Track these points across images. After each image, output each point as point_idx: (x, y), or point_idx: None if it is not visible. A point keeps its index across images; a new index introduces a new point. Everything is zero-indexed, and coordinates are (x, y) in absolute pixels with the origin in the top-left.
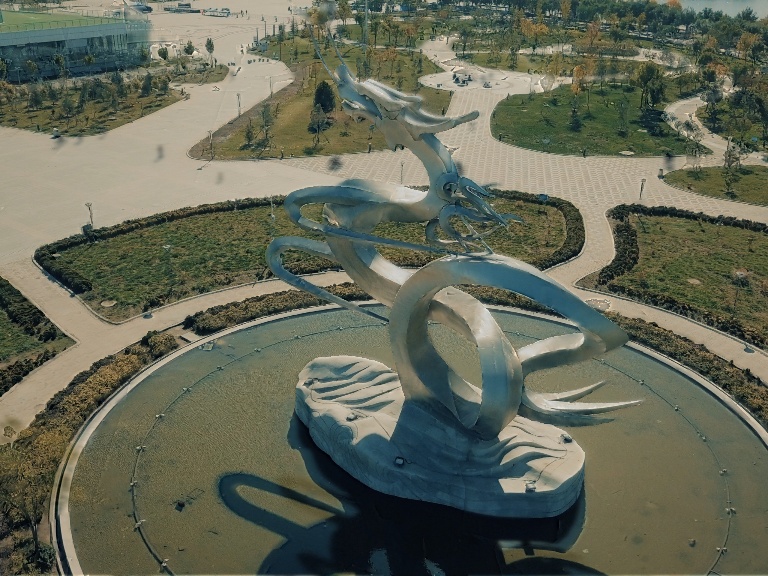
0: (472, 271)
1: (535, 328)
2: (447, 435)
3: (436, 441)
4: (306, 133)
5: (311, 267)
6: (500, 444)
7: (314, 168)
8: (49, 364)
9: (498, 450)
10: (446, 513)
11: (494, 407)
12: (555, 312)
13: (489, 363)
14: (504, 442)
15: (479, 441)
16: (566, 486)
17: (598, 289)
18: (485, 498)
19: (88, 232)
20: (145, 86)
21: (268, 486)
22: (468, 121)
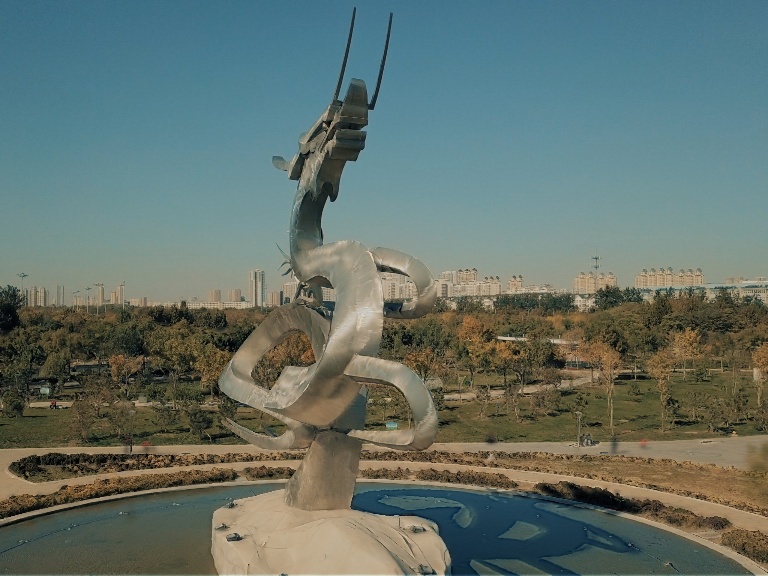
0: None
1: None
2: None
3: None
4: None
5: None
6: None
7: None
8: None
9: None
10: None
11: None
12: None
13: None
14: None
15: None
16: None
17: None
18: None
19: None
20: None
21: None
22: None
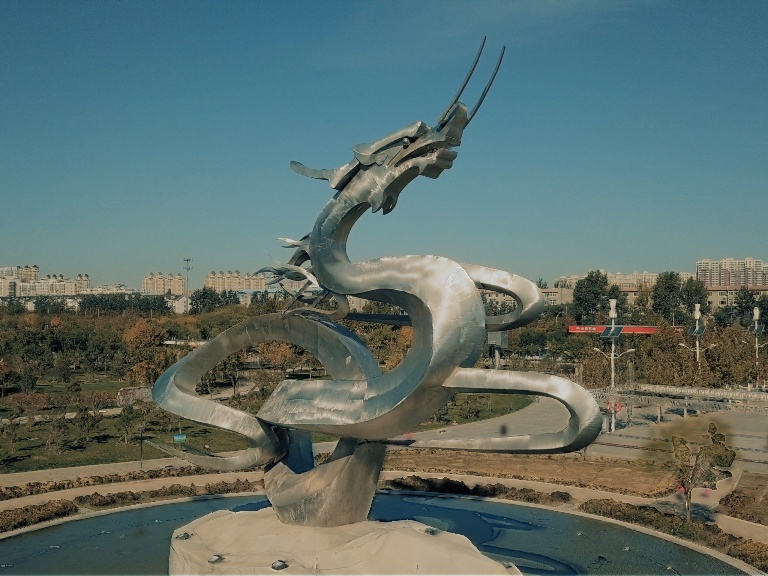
0: None
1: None
2: None
3: None
4: None
5: None
6: None
7: None
8: None
9: None
10: None
11: None
12: None
13: None
14: None
15: None
16: None
17: None
18: None
19: None
20: None
21: (522, 569)
22: None
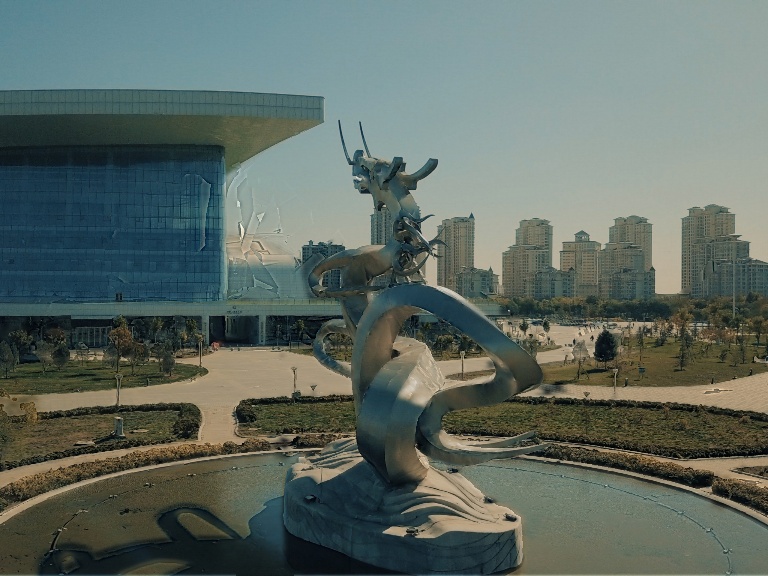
0: (394, 295)
1: (635, 487)
2: (372, 486)
3: (361, 491)
4: (574, 374)
5: (451, 429)
6: (413, 495)
7: (550, 389)
8: (162, 446)
9: (407, 500)
10: (339, 562)
11: (373, 422)
12: (671, 477)
13: (384, 380)
14: (419, 495)
15: (393, 490)
16: (455, 541)
17: (760, 475)
18: (367, 540)
19: (294, 396)
20: (462, 345)
21: (208, 517)
22: (427, 169)
